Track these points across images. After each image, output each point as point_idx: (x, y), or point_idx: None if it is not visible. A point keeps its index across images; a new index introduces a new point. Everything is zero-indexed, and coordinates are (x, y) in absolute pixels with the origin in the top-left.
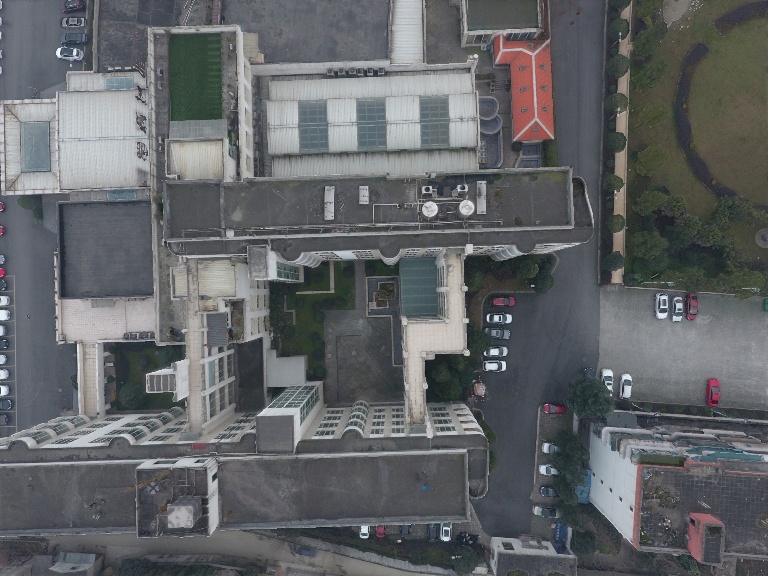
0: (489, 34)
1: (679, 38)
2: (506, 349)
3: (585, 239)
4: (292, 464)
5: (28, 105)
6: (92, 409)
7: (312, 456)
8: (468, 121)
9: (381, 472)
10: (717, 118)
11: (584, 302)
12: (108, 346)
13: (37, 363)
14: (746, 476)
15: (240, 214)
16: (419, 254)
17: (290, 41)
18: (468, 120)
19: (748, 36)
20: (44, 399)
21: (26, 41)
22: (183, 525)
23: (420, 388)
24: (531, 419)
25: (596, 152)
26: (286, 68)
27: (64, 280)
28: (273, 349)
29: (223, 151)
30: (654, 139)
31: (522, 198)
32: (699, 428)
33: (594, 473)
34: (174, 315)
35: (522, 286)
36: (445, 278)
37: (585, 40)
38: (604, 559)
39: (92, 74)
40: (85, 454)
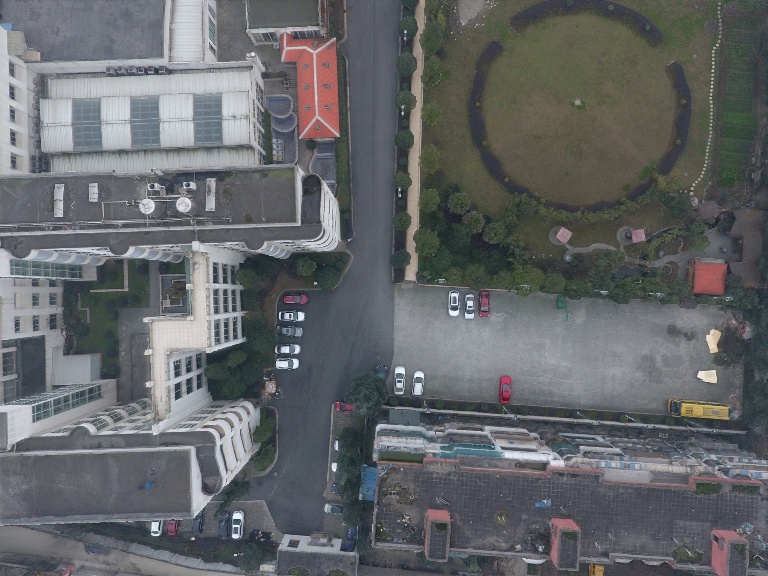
0: (273, 32)
1: (474, 36)
2: (298, 347)
3: (314, 236)
4: (22, 461)
5: None
6: None
7: (37, 453)
8: (241, 119)
9: (110, 469)
10: (512, 116)
11: (378, 300)
12: None
13: None
14: (480, 472)
15: None
16: None
17: (67, 39)
18: (241, 118)
19: (543, 34)
20: None
21: None
22: None
23: None
24: (325, 417)
25: (391, 150)
26: (65, 66)
27: None
28: None
29: None
30: (449, 137)
31: (252, 195)
32: (482, 425)
33: None
34: None
35: None
36: None
37: (381, 38)
38: (396, 556)
39: None
40: None
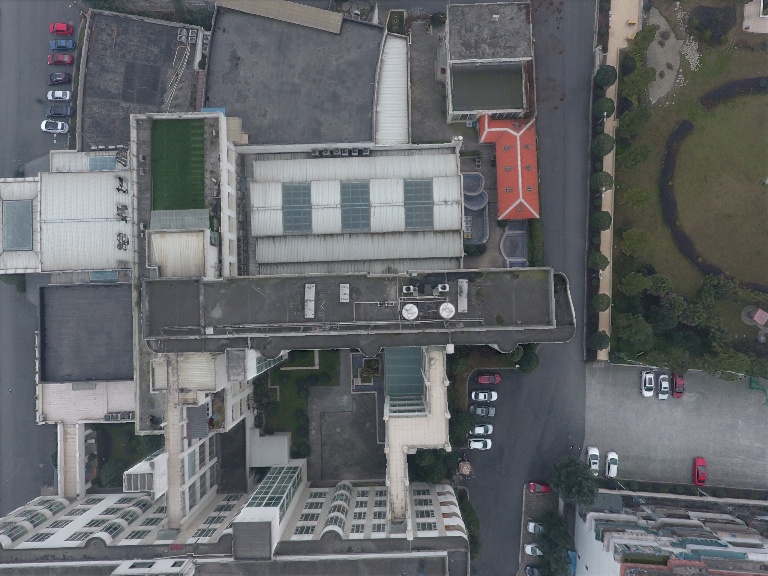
0: (474, 113)
1: (665, 114)
2: (491, 427)
3: (567, 338)
4: (270, 565)
5: (11, 184)
6: (72, 490)
7: (290, 559)
8: (452, 204)
9: (360, 574)
10: (703, 194)
11: (570, 379)
12: (90, 423)
13: (18, 438)
14: None
15: (220, 311)
16: None
17: (274, 122)
18: (452, 203)
19: (733, 113)
20: (25, 475)
21: (11, 113)
22: None
23: (401, 483)
24: (516, 497)
25: (582, 228)
26: (270, 148)
27: (44, 363)
28: (256, 427)
29: (204, 243)
30: (640, 215)
31: (504, 296)
32: (685, 510)
33: (579, 556)
34: (154, 403)
35: (507, 363)
36: (427, 371)
37: (571, 116)
38: None
39: (76, 153)
40: (60, 554)
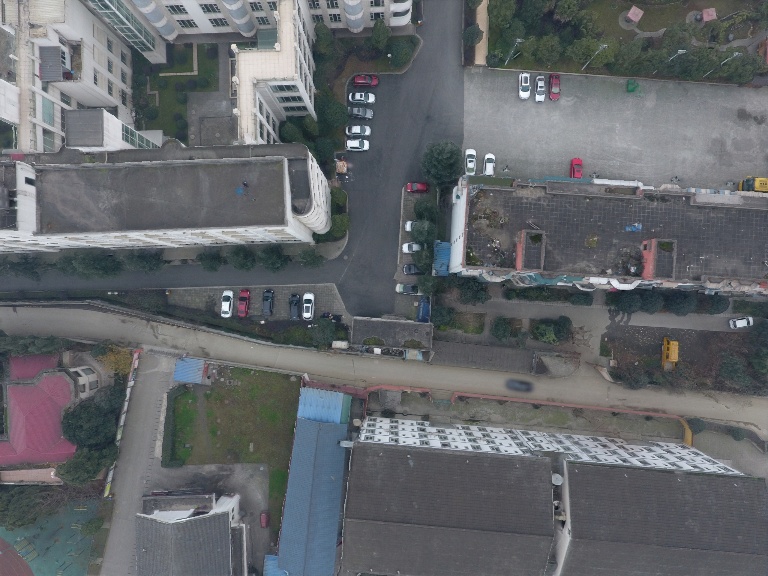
0: None
1: None
2: (369, 128)
3: None
4: (112, 175)
5: None
6: None
7: (129, 162)
8: None
9: (202, 183)
10: None
11: (448, 84)
12: None
13: None
14: (572, 192)
15: None
16: (266, 8)
17: None
18: None
19: None
20: None
21: None
22: None
23: (252, 116)
24: (395, 200)
25: None
26: None
27: None
28: None
29: None
30: None
31: None
32: None
33: (451, 242)
34: None
35: (386, 67)
36: (277, 7)
37: None
38: (468, 338)
39: None
40: None
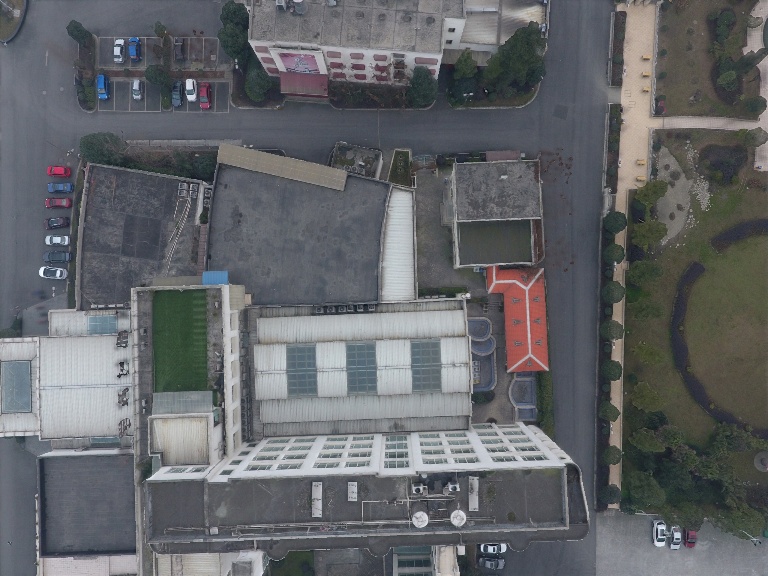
0: (482, 265)
1: (675, 256)
2: None
3: (580, 536)
4: None
5: (9, 344)
6: None
7: None
8: (460, 366)
9: None
10: (714, 338)
11: None
12: None
13: None
14: None
15: (225, 510)
16: None
17: (278, 280)
18: (460, 365)
19: (745, 254)
20: None
21: (8, 257)
22: None
23: None
24: None
25: (591, 373)
26: None
27: (45, 535)
28: None
29: (208, 430)
30: None
31: (515, 492)
32: None
33: None
34: None
35: None
36: (437, 559)
37: (580, 258)
38: None
39: (75, 312)
40: None
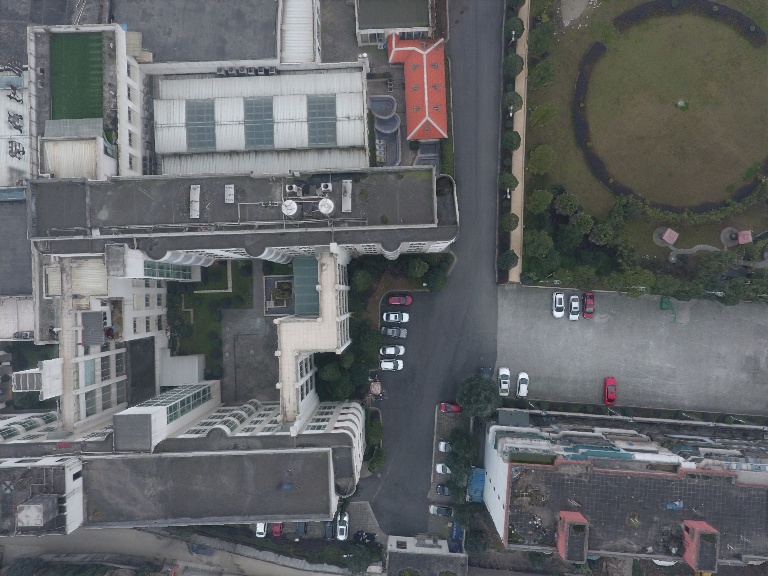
0: (381, 33)
1: (577, 37)
2: (403, 348)
3: (450, 237)
4: (158, 463)
5: None
6: None
7: (175, 455)
8: (355, 120)
9: (246, 471)
10: (615, 117)
11: (482, 301)
12: (4, 345)
13: None
14: (614, 474)
15: (106, 213)
16: (304, 253)
17: (179, 40)
18: (355, 119)
19: (646, 35)
20: None
21: None
22: (33, 524)
23: (293, 387)
24: (428, 418)
25: (494, 151)
26: (176, 67)
27: None
28: (169, 348)
29: (96, 150)
30: (552, 138)
31: (388, 196)
32: None
33: (486, 472)
34: None
35: (420, 285)
36: None
37: (483, 39)
38: (501, 558)
39: None
40: None
